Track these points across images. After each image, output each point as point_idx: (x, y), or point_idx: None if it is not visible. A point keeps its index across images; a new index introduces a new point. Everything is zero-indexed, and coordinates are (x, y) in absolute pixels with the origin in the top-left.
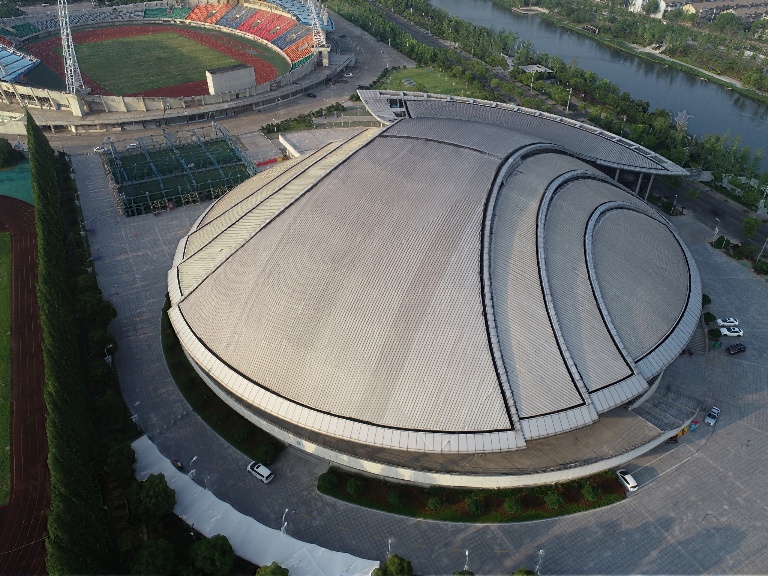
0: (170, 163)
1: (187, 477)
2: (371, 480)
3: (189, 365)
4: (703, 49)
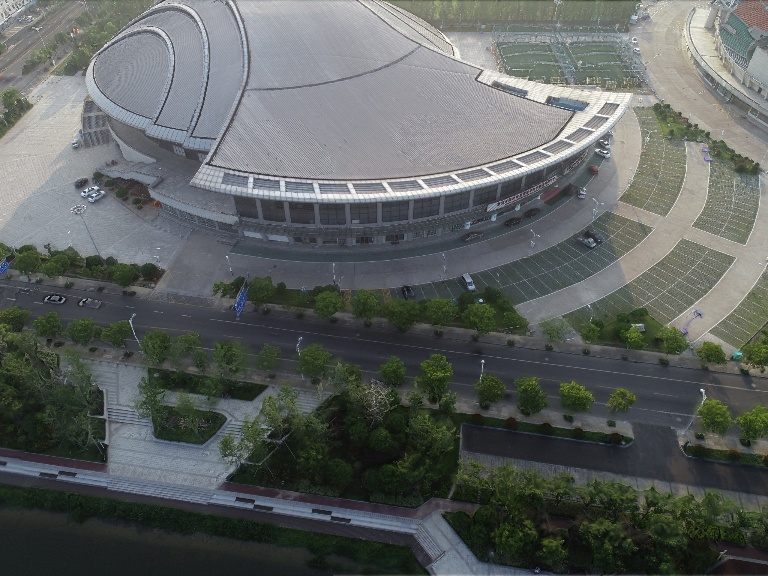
0: (590, 61)
1: None
2: None
3: None
4: None
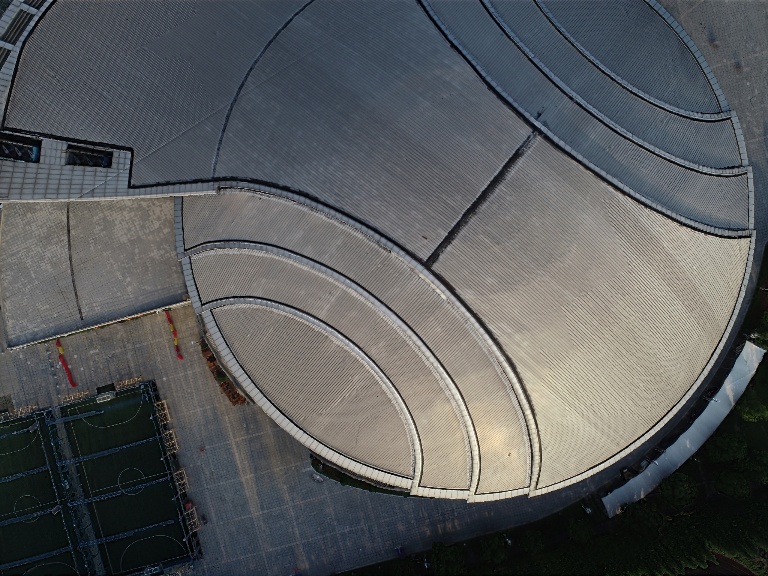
0: None
1: (651, 465)
2: None
3: None
4: None
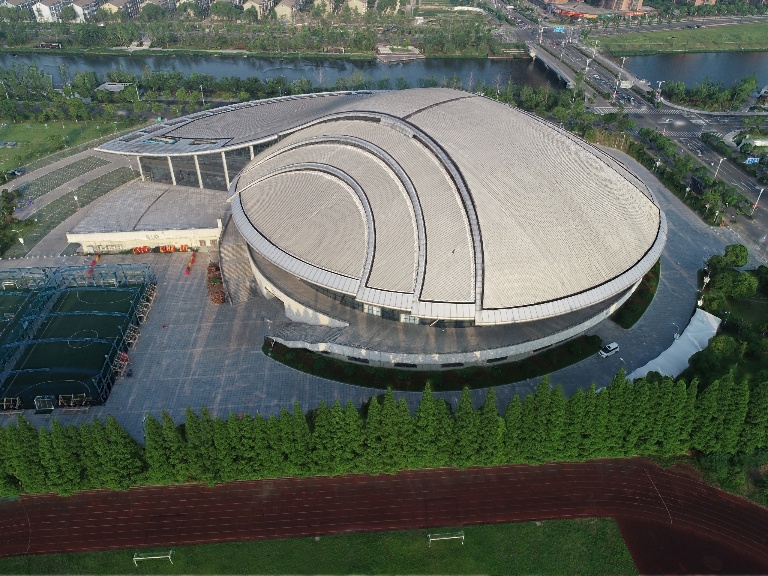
0: None
1: None
2: (627, 302)
3: (474, 371)
4: (183, 35)
